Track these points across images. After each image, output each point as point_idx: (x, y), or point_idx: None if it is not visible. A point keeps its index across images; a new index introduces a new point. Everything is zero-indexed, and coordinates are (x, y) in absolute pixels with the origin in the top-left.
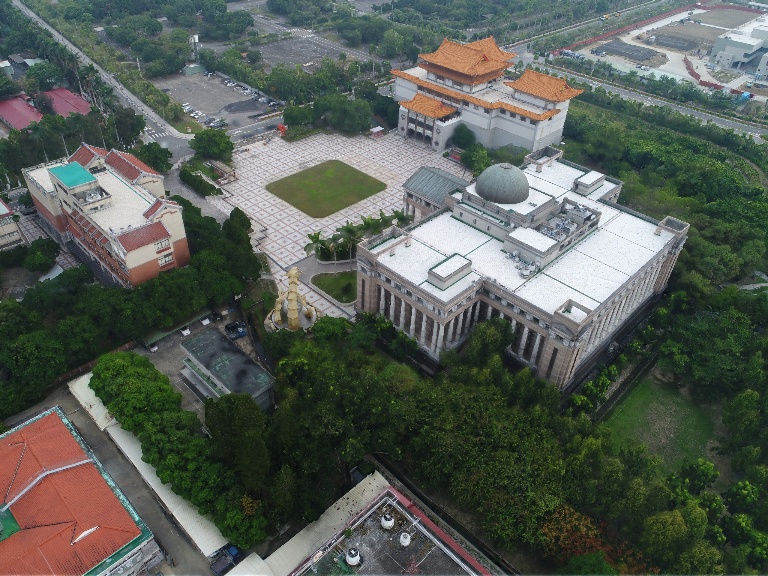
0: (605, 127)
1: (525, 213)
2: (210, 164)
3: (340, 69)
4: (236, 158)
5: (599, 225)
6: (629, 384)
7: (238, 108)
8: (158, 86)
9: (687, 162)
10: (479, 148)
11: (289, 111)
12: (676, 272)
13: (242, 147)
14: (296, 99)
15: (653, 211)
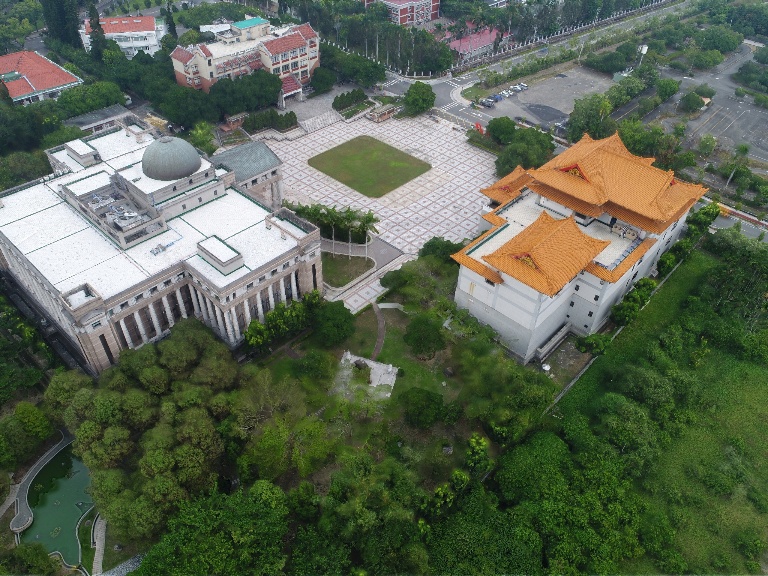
0: (616, 427)
1: (122, 173)
2: (399, 107)
3: (664, 143)
4: (420, 119)
5: (129, 252)
6: (1, 333)
7: (540, 111)
8: (570, 72)
9: (399, 478)
10: (441, 243)
11: (495, 118)
12: (100, 376)
13: (444, 119)
14: (574, 134)
15: (249, 391)
